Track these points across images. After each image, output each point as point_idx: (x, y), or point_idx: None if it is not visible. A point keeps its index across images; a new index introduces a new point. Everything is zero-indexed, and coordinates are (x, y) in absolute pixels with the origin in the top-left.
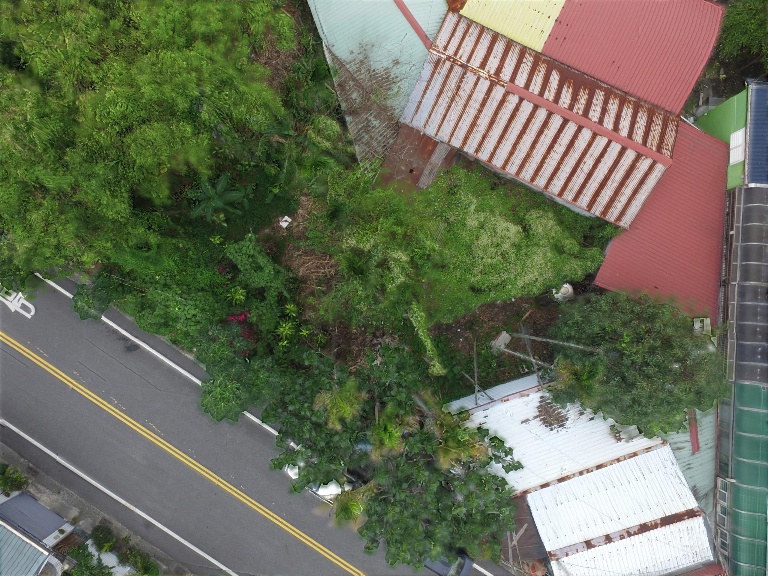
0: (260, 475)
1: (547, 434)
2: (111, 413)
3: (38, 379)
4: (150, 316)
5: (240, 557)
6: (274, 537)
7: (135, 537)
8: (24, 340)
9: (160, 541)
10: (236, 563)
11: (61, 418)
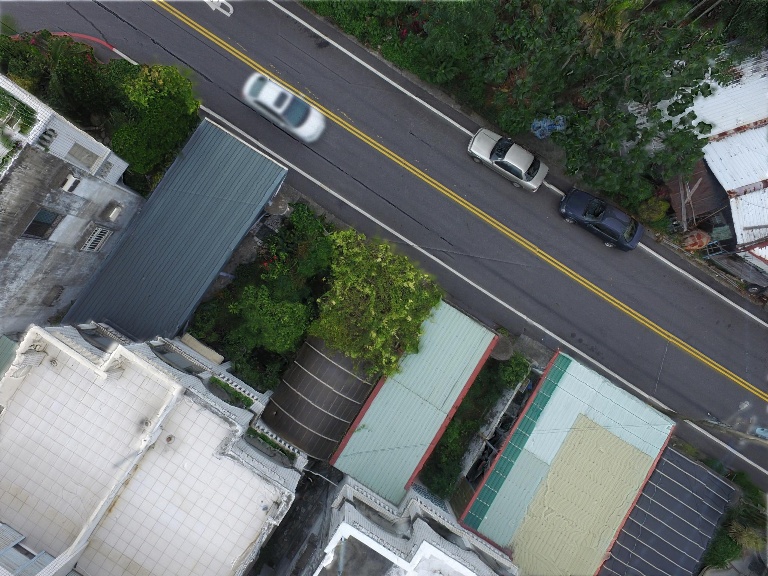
0: (442, 160)
1: (723, 89)
2: (306, 102)
3: (239, 71)
4: None
5: (426, 233)
6: (456, 216)
7: (330, 215)
8: (225, 36)
9: (352, 219)
10: (422, 239)
11: (260, 107)
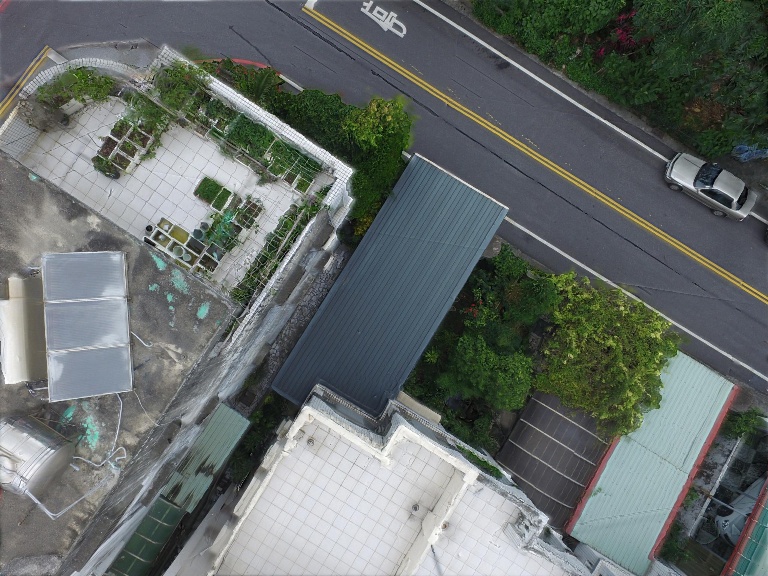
0: (635, 188)
1: None
2: (488, 128)
3: (414, 96)
4: (540, 17)
5: (620, 268)
6: (652, 248)
7: (516, 251)
8: (398, 59)
9: (540, 254)
10: (617, 274)
11: (438, 135)
